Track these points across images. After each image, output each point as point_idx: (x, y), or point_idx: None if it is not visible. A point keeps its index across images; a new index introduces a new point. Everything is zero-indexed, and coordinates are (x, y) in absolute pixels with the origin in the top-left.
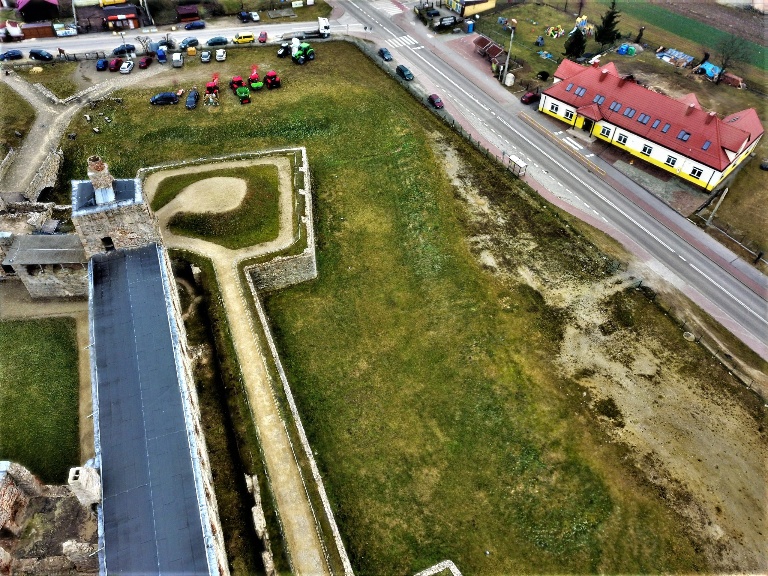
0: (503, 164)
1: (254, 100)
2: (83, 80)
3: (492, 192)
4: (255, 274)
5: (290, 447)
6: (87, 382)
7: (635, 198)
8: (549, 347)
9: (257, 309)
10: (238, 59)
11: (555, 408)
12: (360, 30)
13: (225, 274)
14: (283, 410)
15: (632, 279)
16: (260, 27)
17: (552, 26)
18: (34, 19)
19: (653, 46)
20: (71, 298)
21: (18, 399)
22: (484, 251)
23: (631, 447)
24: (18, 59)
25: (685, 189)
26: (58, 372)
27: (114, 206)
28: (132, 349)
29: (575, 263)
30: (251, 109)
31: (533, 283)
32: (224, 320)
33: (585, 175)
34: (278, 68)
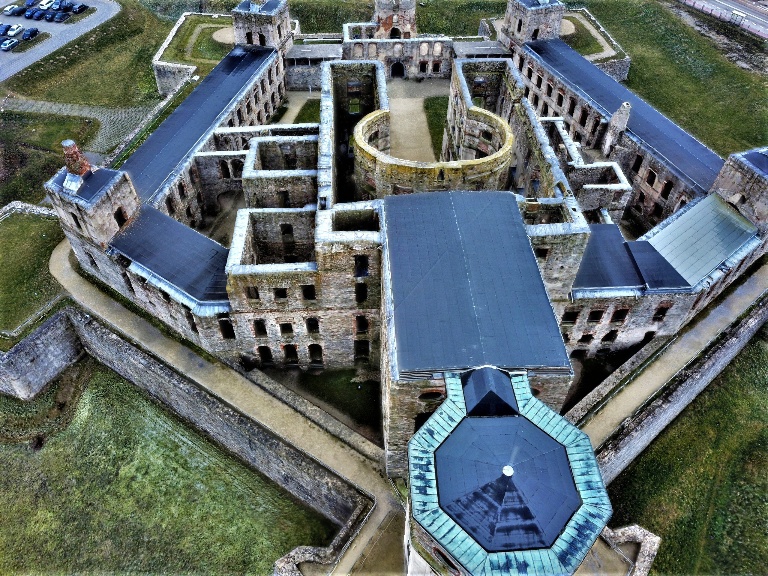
0: (725, 18)
1: None
2: None
3: (726, 33)
4: None
5: None
6: None
7: None
8: None
9: None
10: None
11: None
12: None
13: None
14: None
15: None
16: None
17: None
18: None
19: None
20: None
21: None
22: (738, 61)
23: None
24: None
25: None
26: None
27: (549, 6)
28: (590, 77)
29: None
30: None
31: None
32: None
33: None
34: None
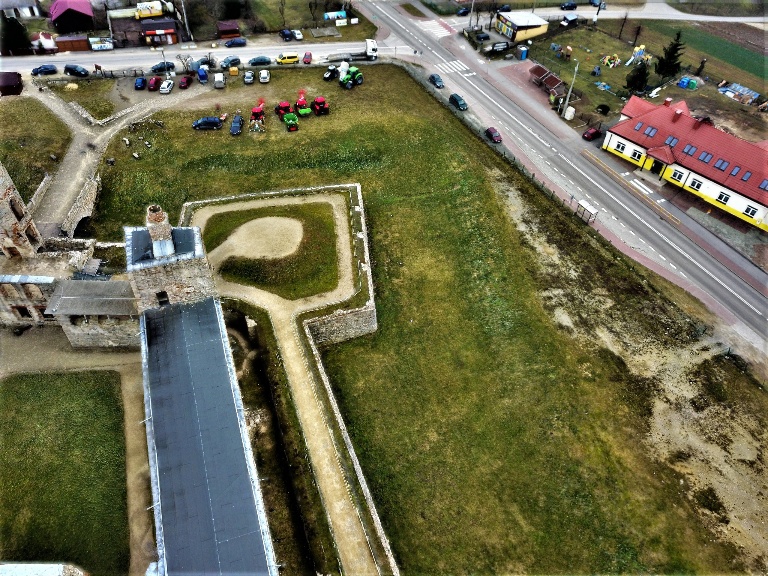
0: (570, 208)
1: (302, 127)
2: (121, 99)
3: (561, 240)
4: (314, 328)
5: (366, 541)
6: (134, 449)
7: (713, 251)
8: (638, 424)
9: (320, 371)
10: (282, 81)
11: (651, 497)
12: (408, 53)
13: (283, 329)
14: (355, 495)
15: (720, 345)
16: (303, 46)
17: (607, 54)
18: (68, 30)
19: (714, 80)
20: (114, 348)
21: (59, 467)
22: (558, 308)
23: (739, 548)
24: (52, 74)
25: (766, 242)
26: (102, 436)
27: (173, 260)
28: (194, 427)
29: (657, 325)
30: (299, 137)
31: (614, 347)
32: (285, 383)
33: (657, 223)
34: (325, 92)
